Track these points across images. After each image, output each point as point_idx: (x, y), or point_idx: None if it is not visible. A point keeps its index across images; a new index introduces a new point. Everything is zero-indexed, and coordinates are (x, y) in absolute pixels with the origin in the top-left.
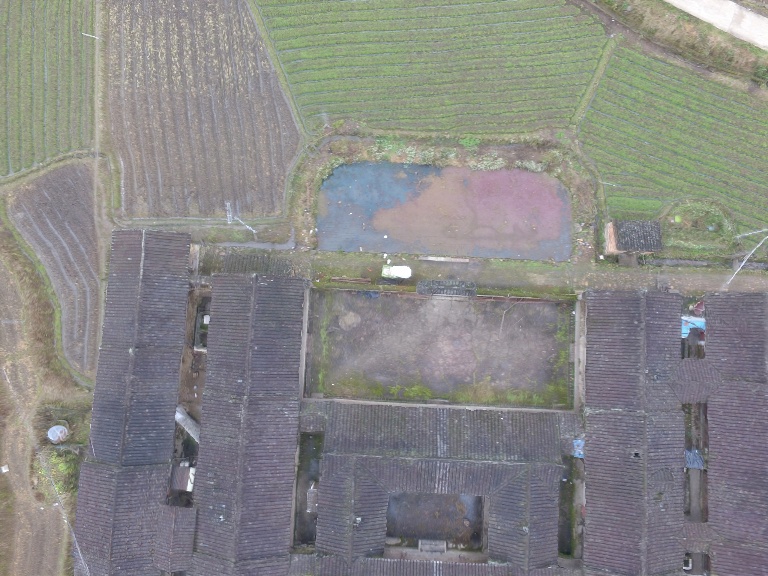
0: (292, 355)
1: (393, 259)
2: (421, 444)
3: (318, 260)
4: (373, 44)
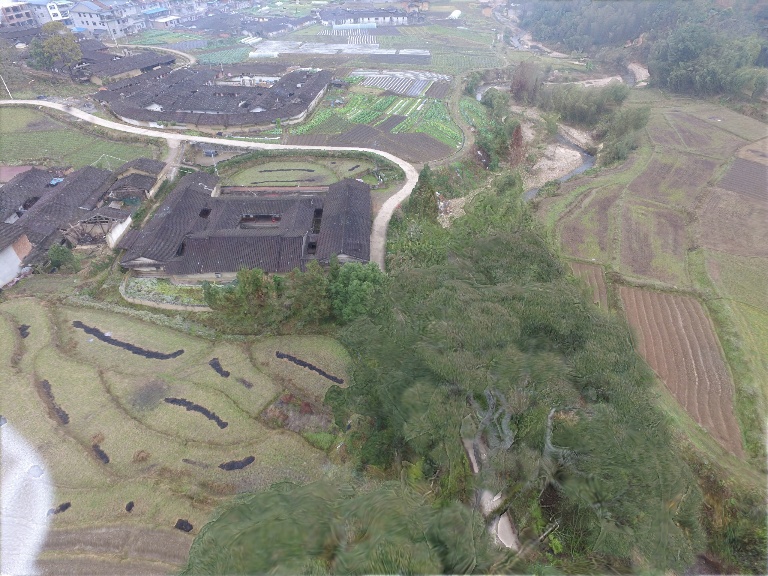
0: None
1: None
2: None
3: None
4: None
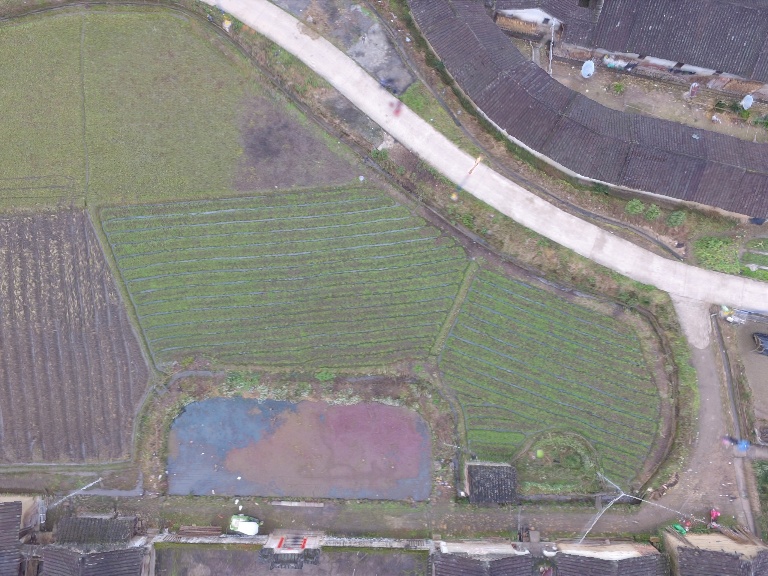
0: None
1: (245, 504)
2: None
3: (167, 507)
4: (226, 272)
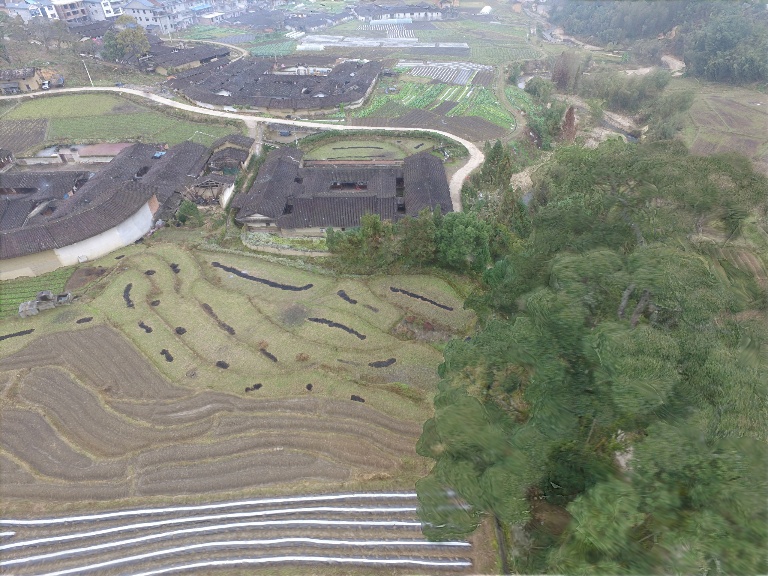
0: None
1: None
2: None
3: None
4: None
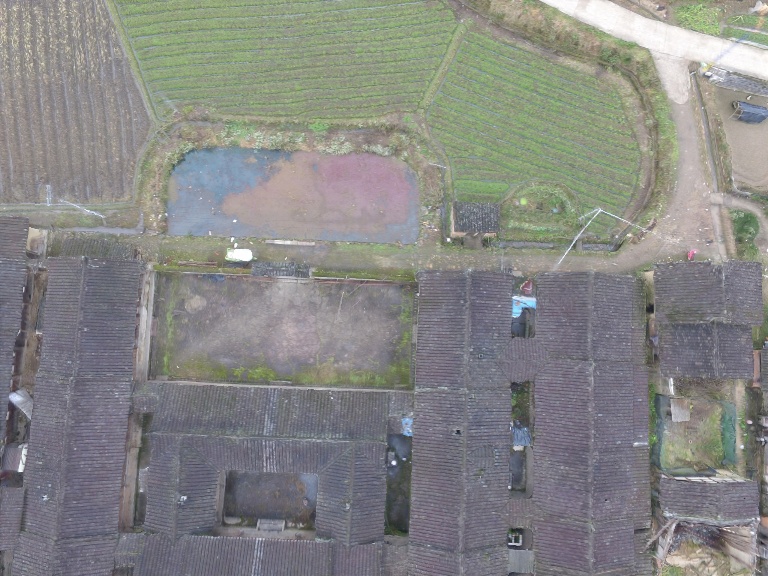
0: (125, 337)
1: (241, 243)
2: (248, 423)
3: (166, 244)
4: (225, 30)
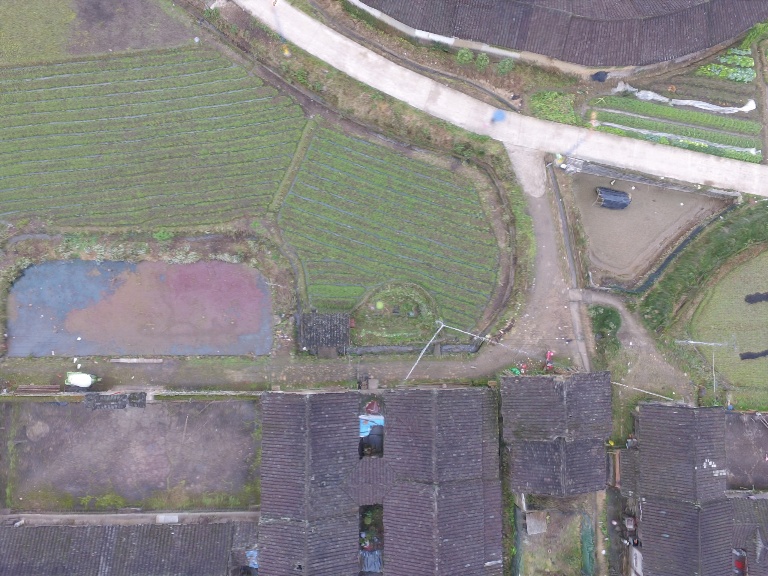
0: None
1: (84, 363)
2: (82, 568)
3: (5, 368)
4: (61, 136)
